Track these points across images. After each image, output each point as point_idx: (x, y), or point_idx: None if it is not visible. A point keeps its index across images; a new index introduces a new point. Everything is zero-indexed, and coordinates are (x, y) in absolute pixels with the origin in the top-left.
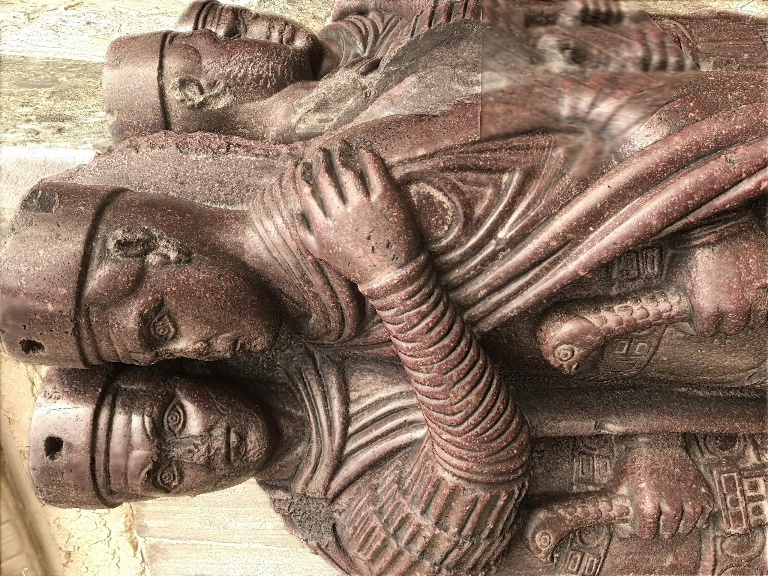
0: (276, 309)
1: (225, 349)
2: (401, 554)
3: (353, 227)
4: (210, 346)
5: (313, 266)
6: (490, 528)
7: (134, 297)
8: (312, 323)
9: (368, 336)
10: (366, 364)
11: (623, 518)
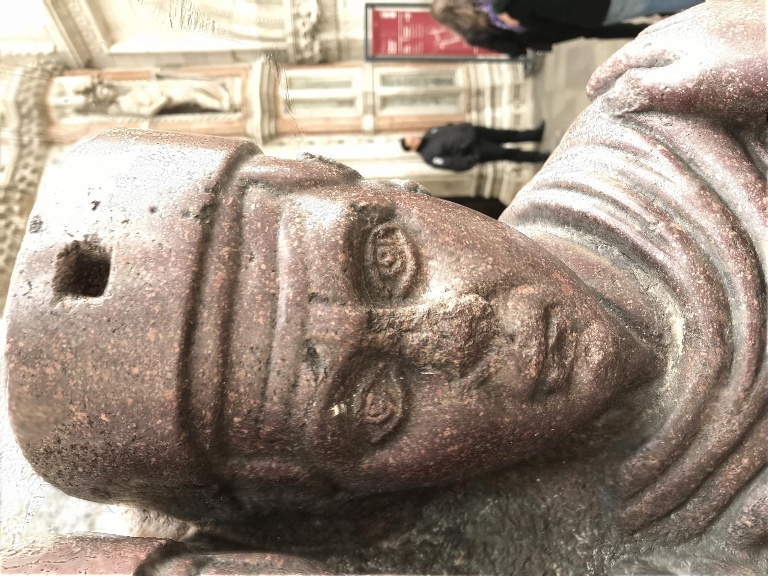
0: None
1: (527, 326)
2: None
3: (746, 2)
4: (492, 314)
5: (671, 160)
6: None
7: (339, 190)
8: (673, 378)
9: None
10: None
11: None
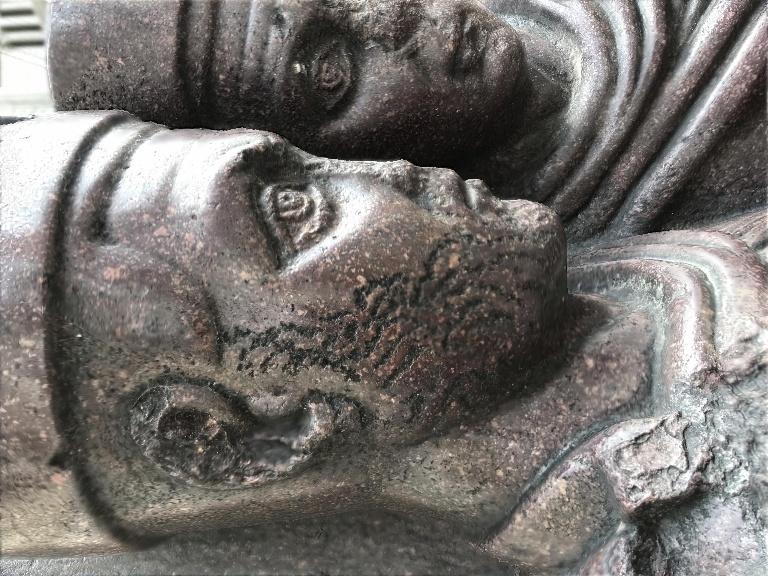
0: None
1: (447, 15)
2: None
3: None
4: (420, 6)
5: None
6: None
7: None
8: (575, 101)
9: (690, 52)
10: (695, 228)
11: None
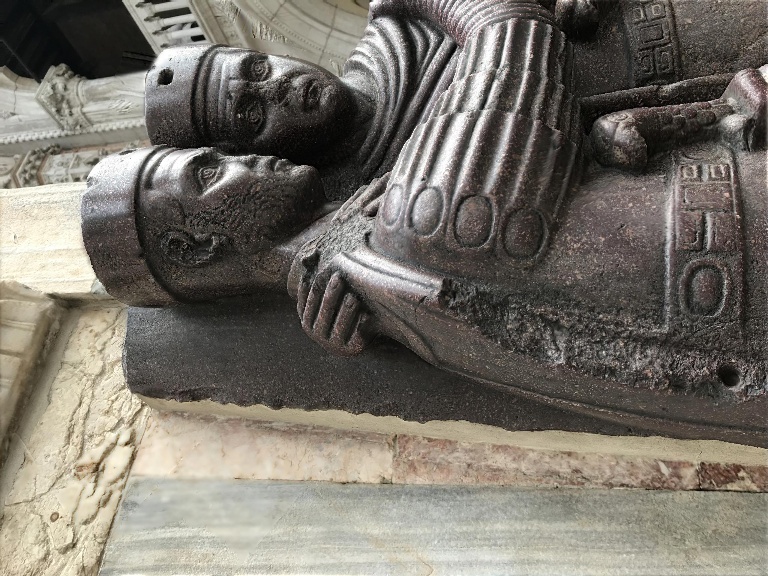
0: (348, 91)
1: (301, 85)
2: (435, 123)
3: None
4: (290, 82)
5: (379, 33)
6: (530, 58)
7: None
8: None
9: (420, 86)
10: None
11: (722, 105)
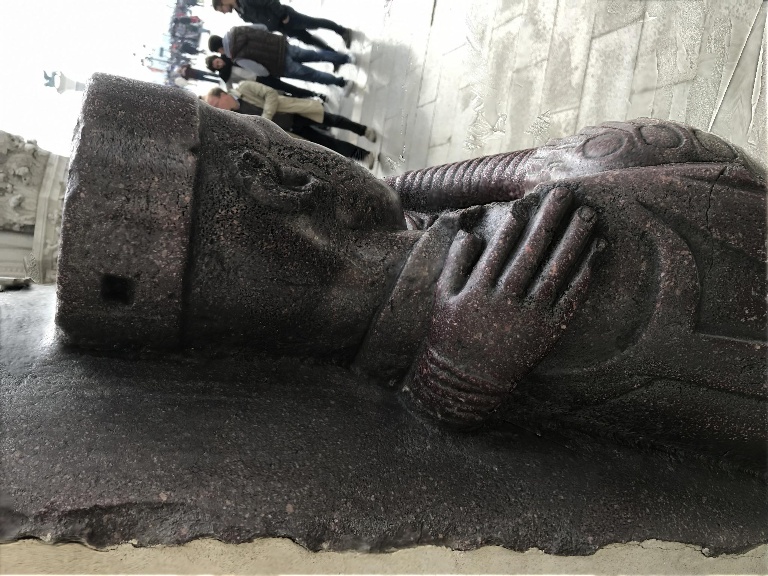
0: None
1: None
2: None
3: None
4: None
5: None
6: None
7: None
8: None
9: None
10: None
11: None
